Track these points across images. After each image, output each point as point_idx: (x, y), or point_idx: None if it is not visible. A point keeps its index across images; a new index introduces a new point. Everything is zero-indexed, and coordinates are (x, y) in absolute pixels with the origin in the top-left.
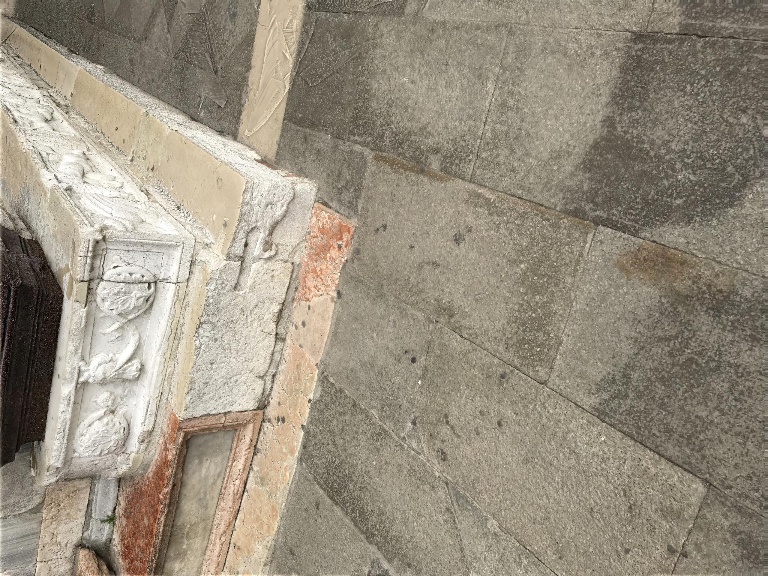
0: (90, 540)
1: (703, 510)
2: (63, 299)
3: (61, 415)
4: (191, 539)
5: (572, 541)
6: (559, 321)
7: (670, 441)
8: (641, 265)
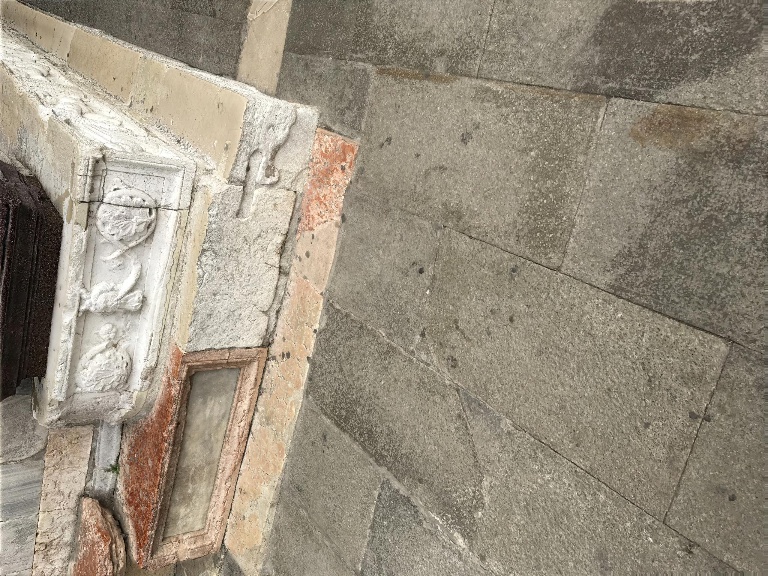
0: (93, 490)
1: (726, 369)
2: (63, 225)
3: (62, 345)
4: (196, 483)
5: (589, 426)
6: (572, 202)
7: (690, 305)
8: (656, 130)
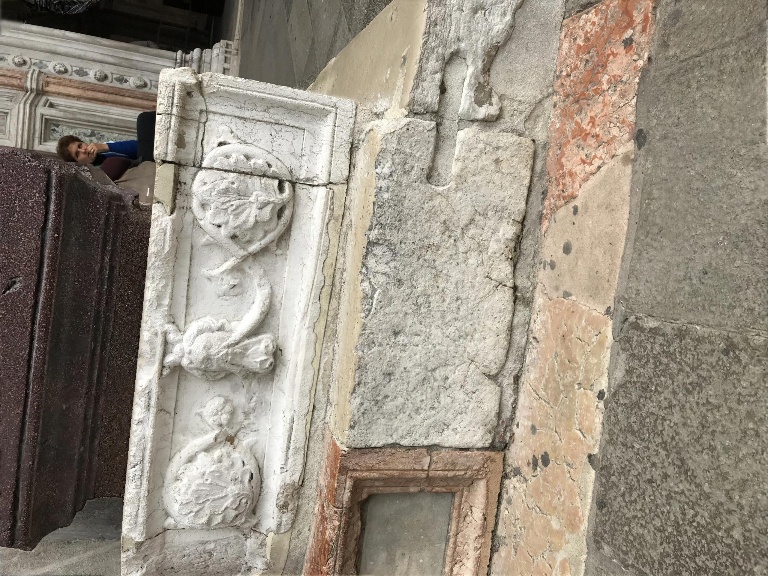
0: None
1: None
2: None
3: (136, 429)
4: None
5: None
6: None
7: None
8: None
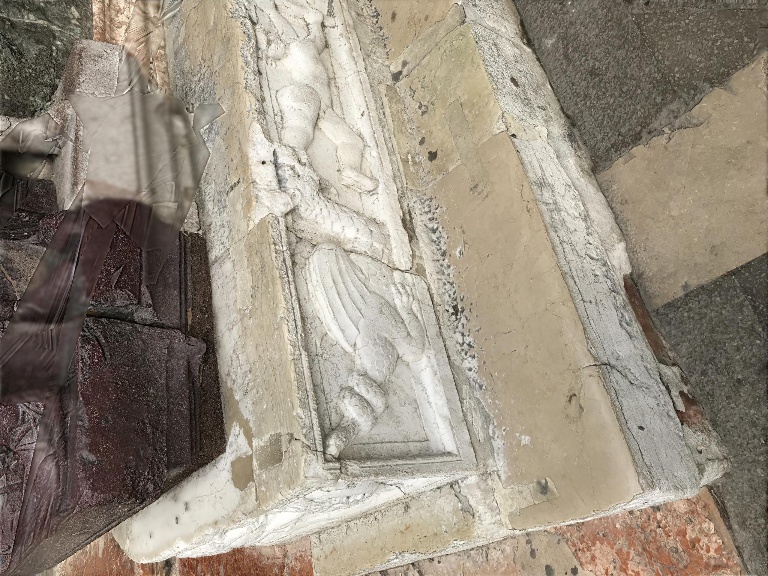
0: None
1: None
2: (222, 454)
3: (164, 554)
4: None
5: None
6: None
7: None
8: None
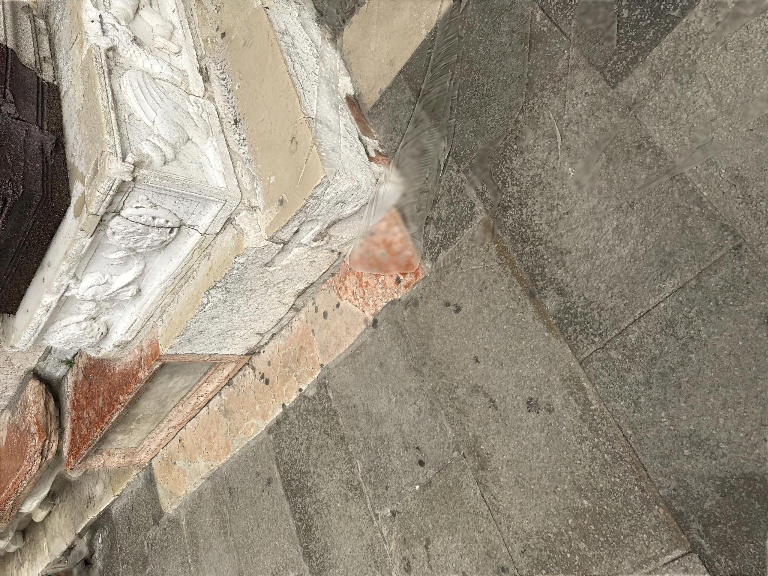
0: (44, 370)
1: None
2: (69, 206)
3: (37, 316)
4: (140, 423)
5: None
6: None
7: None
8: None
